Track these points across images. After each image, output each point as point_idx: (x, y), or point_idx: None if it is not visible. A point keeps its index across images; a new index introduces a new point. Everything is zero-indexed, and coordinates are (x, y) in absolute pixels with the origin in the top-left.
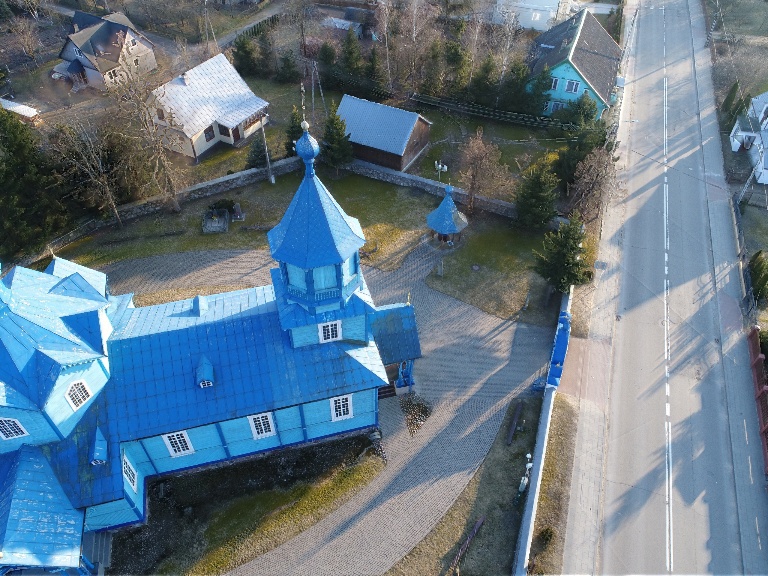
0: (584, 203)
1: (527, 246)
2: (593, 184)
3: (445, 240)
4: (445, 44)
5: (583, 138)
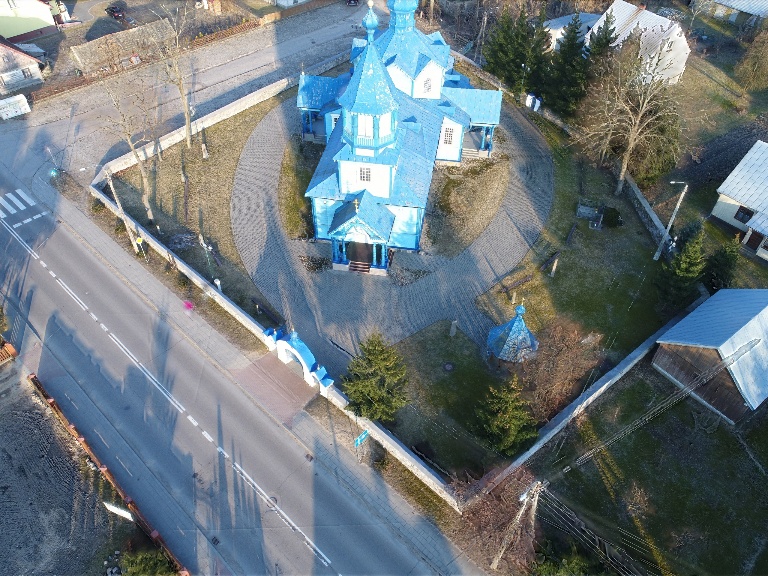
0: (472, 479)
1: None
2: None
3: None
4: None
5: None
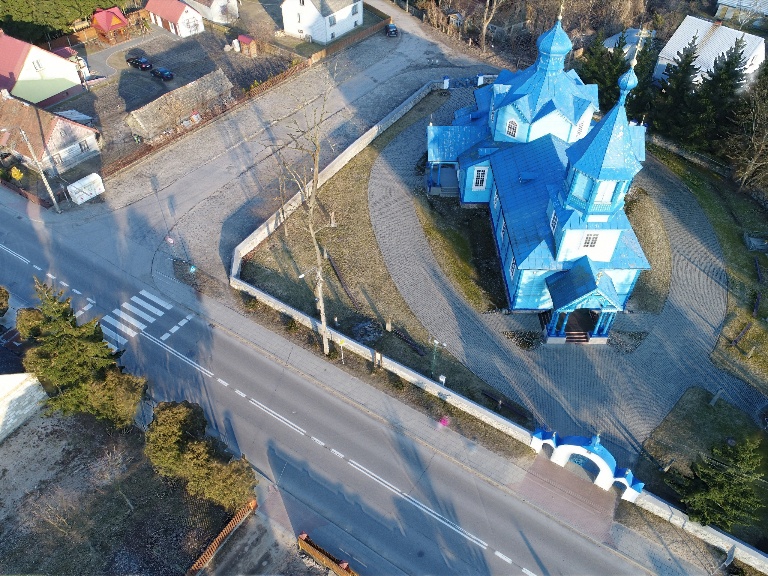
0: None
1: None
2: None
3: None
4: None
5: None
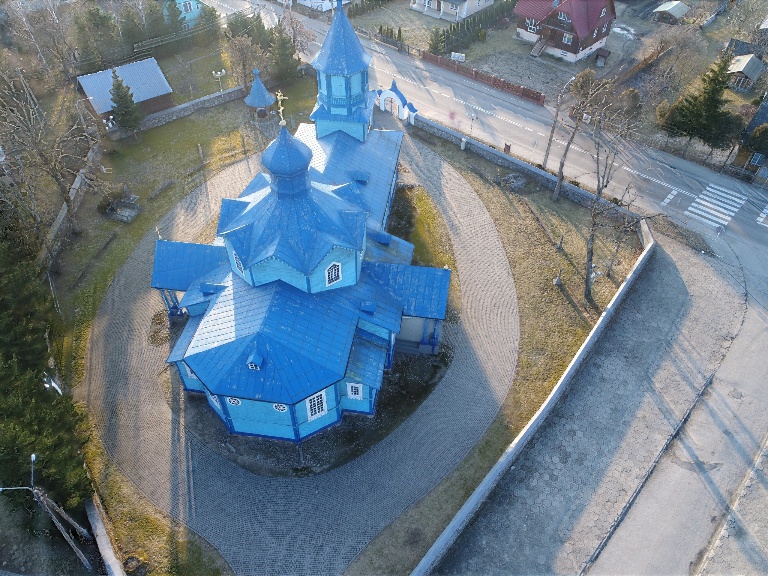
0: (304, 48)
1: (300, 91)
2: (294, 37)
3: (266, 115)
4: (88, 12)
5: (243, 26)
